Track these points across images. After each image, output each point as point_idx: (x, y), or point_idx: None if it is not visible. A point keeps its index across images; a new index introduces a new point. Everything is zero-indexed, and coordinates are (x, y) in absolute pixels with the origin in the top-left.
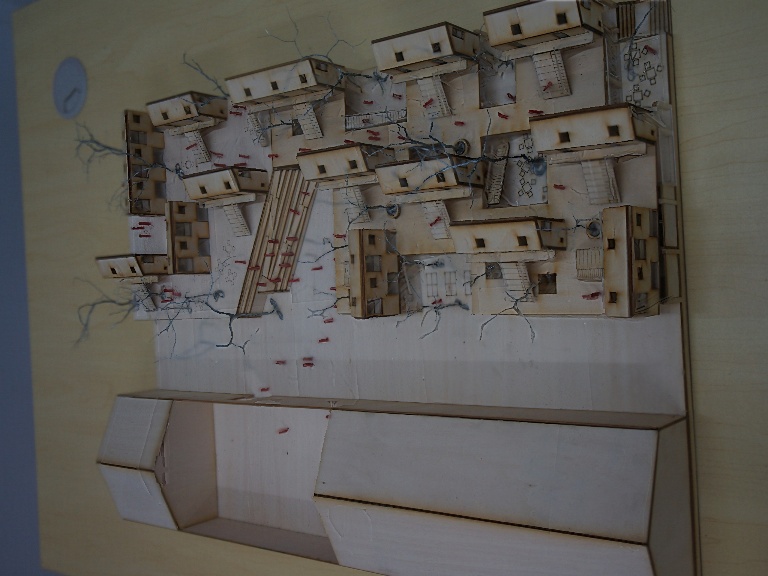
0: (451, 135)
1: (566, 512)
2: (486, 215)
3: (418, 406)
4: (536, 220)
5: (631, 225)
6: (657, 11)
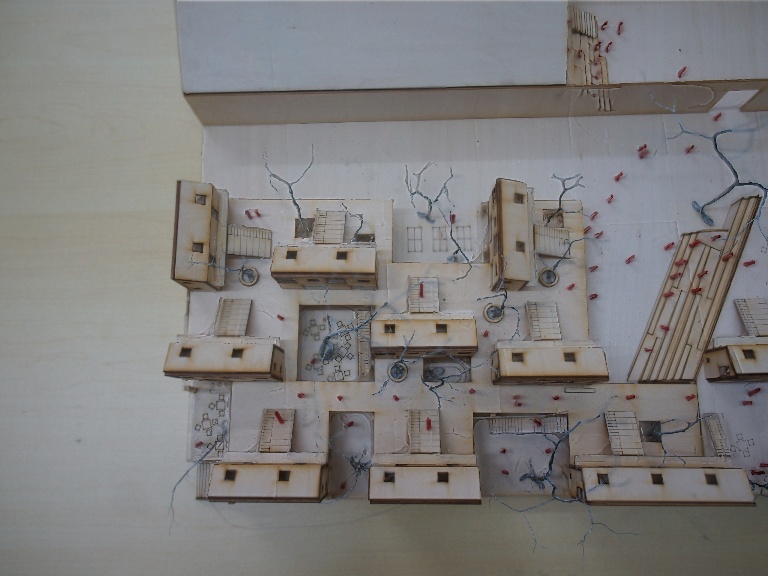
0: (412, 389)
1: (251, 7)
2: (371, 299)
3: (471, 109)
4: (271, 273)
5: (172, 262)
6: (204, 486)
